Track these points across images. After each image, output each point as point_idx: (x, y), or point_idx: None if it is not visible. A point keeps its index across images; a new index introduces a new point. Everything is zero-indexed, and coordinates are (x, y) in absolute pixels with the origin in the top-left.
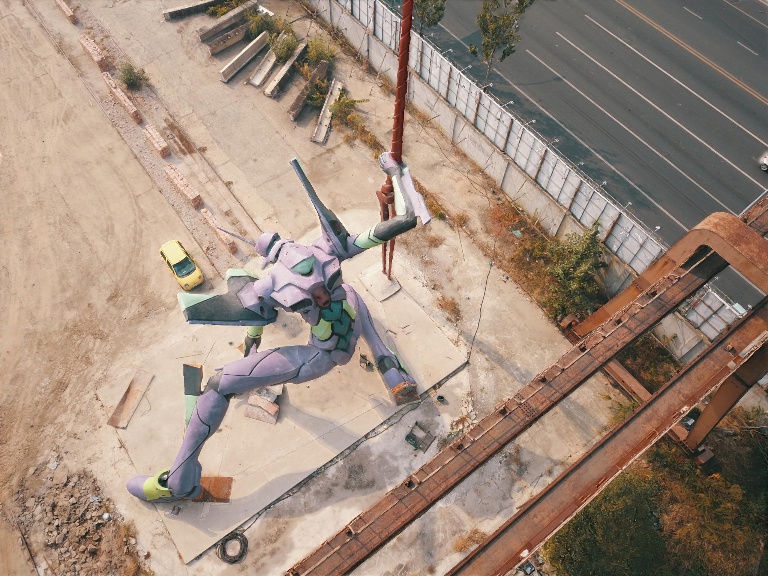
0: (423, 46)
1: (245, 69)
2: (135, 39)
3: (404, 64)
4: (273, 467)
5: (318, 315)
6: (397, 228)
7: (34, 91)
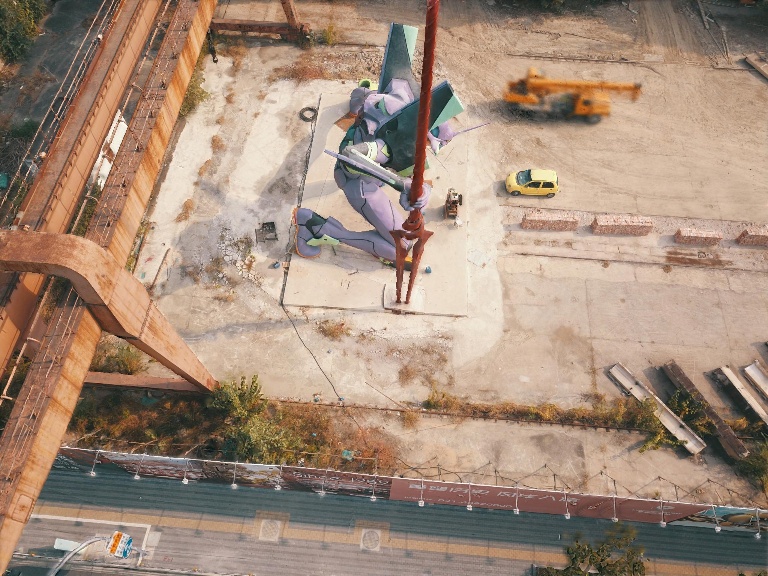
0: None
1: None
2: None
3: None
4: None
5: None
6: None
7: None
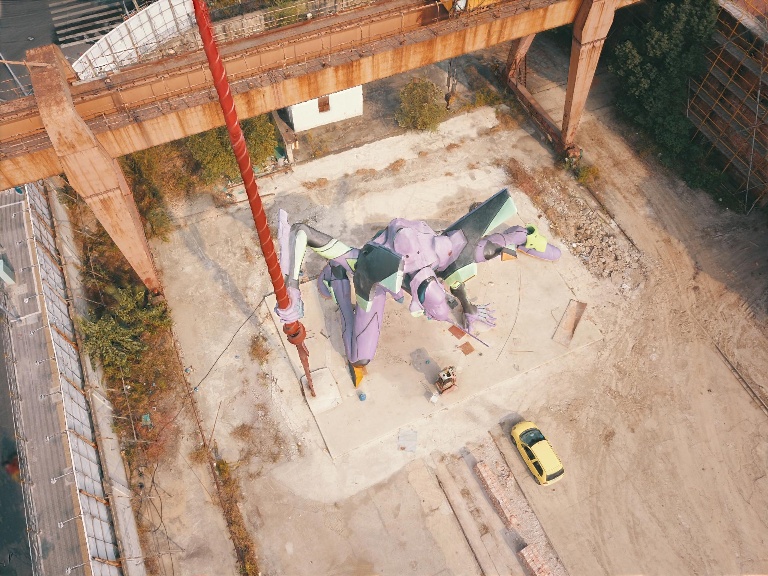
0: None
1: None
2: None
3: None
4: None
5: None
6: None
7: None
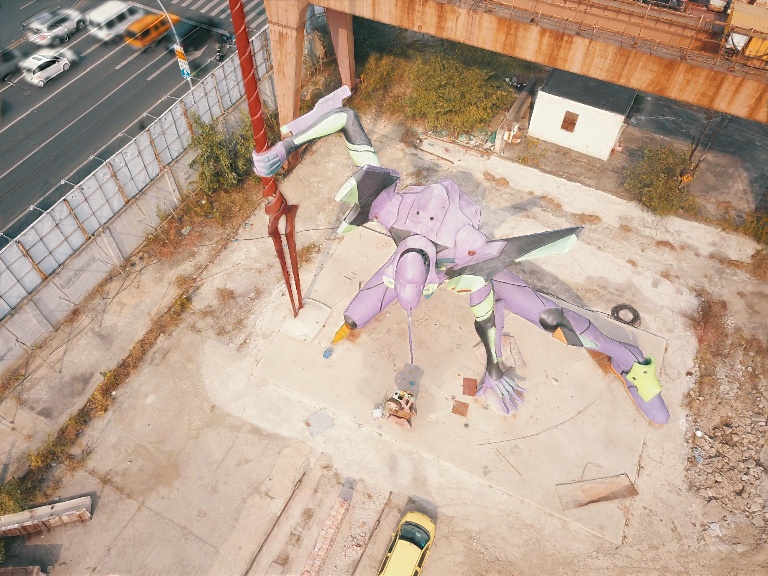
0: None
1: None
2: None
3: None
4: None
5: None
6: None
7: None
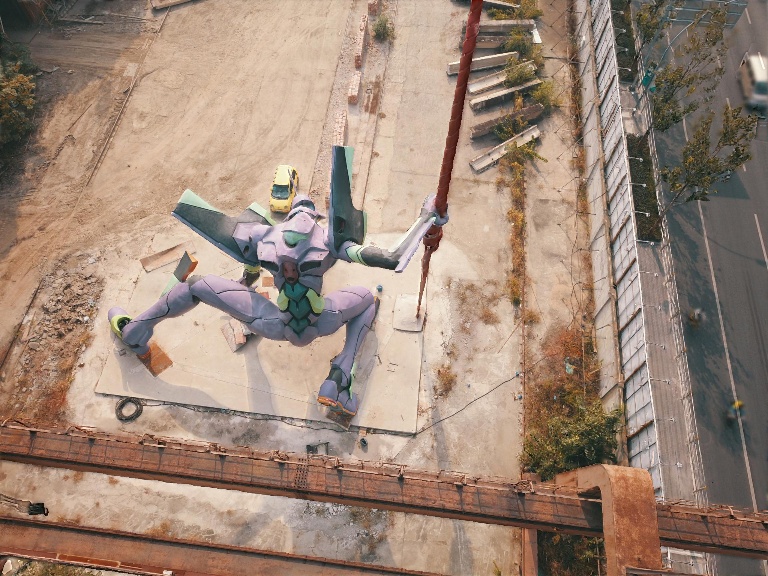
0: (620, 140)
1: (474, 74)
2: (415, 2)
3: (454, 117)
4: (203, 380)
5: (282, 285)
6: (378, 259)
7: (313, 1)
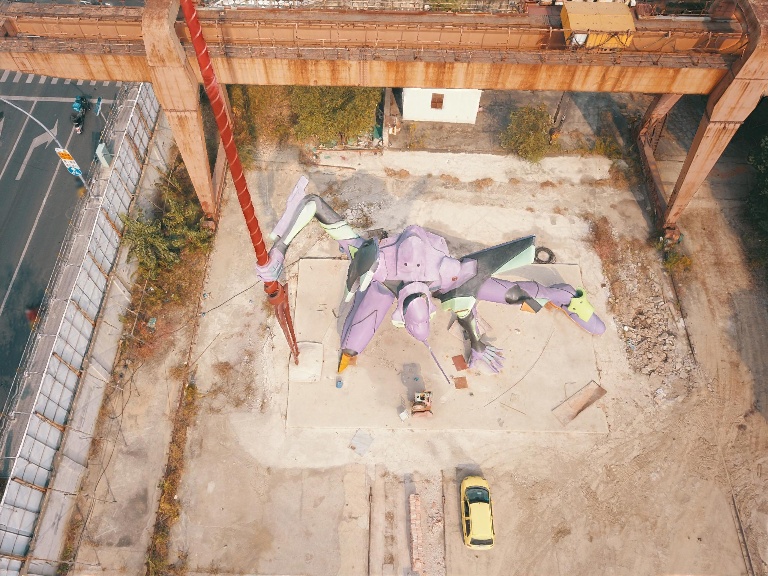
0: None
1: None
2: None
3: None
4: None
5: None
6: None
7: None
